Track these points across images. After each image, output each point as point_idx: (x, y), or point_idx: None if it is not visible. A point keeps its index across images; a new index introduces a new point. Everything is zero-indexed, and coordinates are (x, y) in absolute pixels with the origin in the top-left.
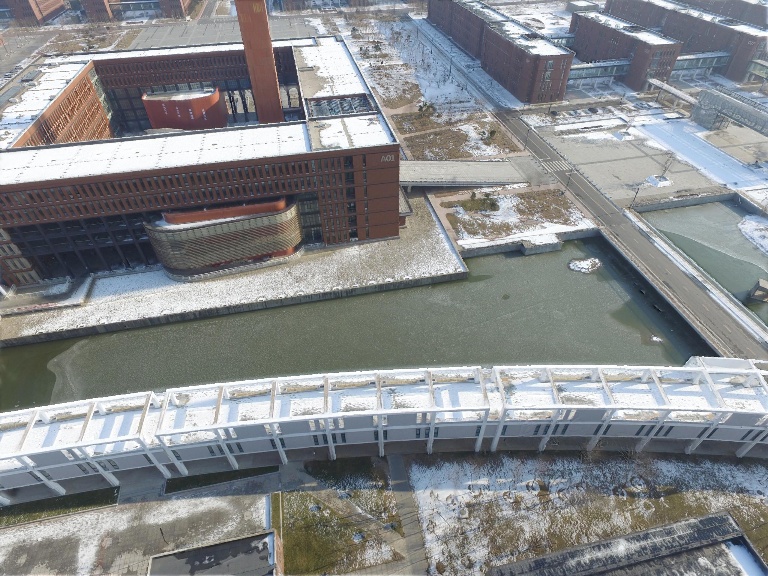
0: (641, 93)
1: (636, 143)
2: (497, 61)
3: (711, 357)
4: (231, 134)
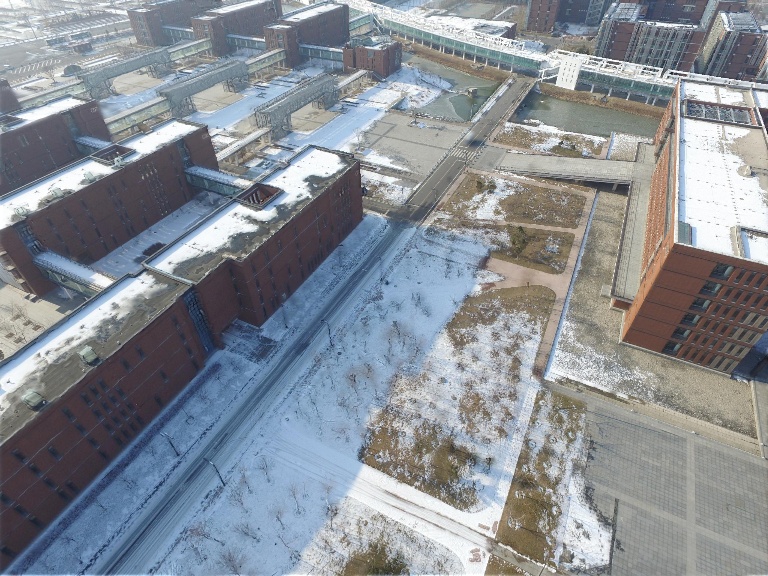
0: None
1: (368, 144)
2: (301, 255)
3: (576, 59)
4: None
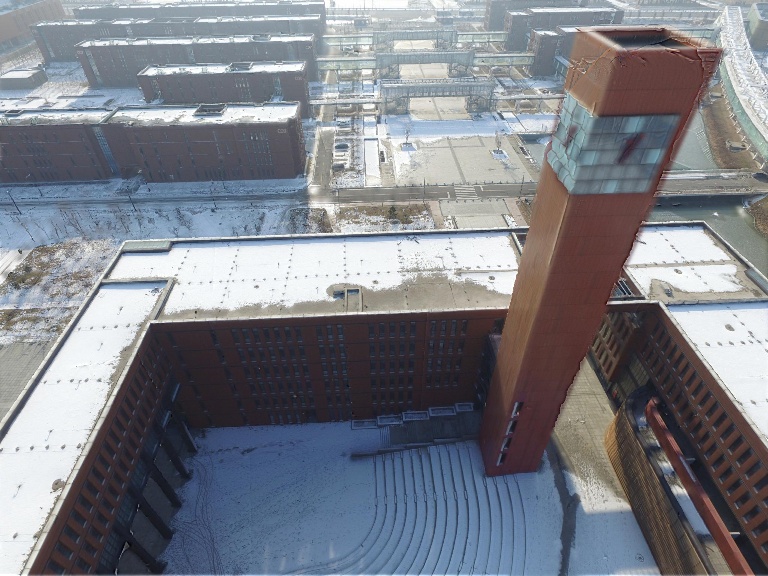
0: (314, 117)
1: (425, 146)
2: (194, 158)
3: None
4: (766, 422)
